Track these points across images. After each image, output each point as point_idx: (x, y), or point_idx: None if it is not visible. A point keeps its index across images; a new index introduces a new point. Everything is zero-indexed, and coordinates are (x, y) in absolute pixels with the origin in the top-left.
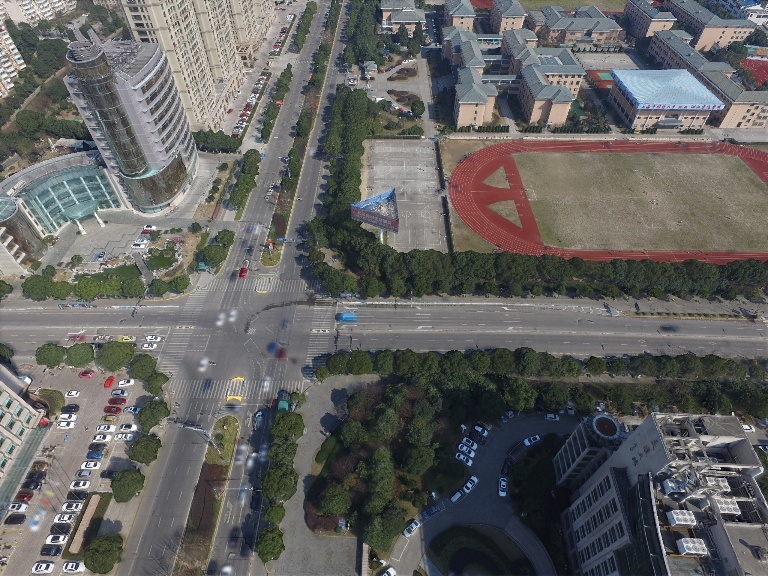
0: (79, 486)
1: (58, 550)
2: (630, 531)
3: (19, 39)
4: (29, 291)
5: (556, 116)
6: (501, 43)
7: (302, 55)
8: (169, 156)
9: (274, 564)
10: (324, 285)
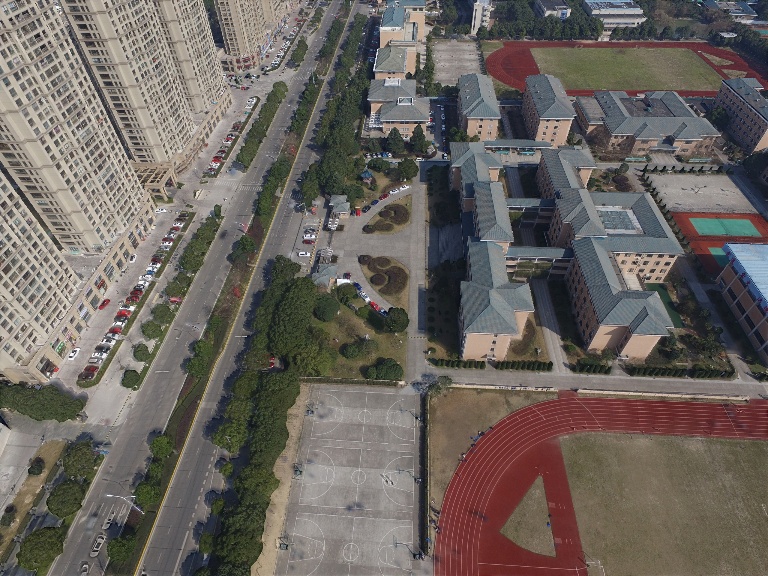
0: None
1: None
2: None
3: None
4: None
5: (636, 348)
6: None
7: (249, 174)
8: None
9: None
10: None
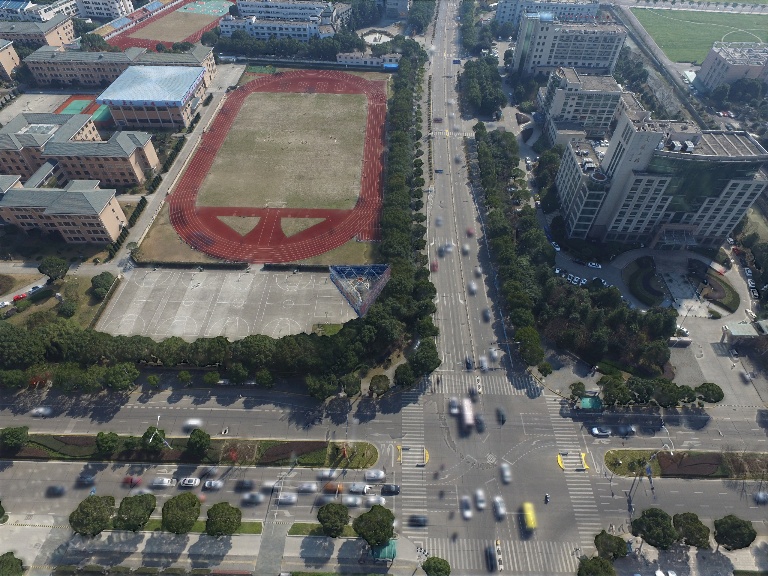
0: None
1: None
2: None
3: None
4: None
5: (152, 158)
6: None
7: None
8: None
9: None
10: None
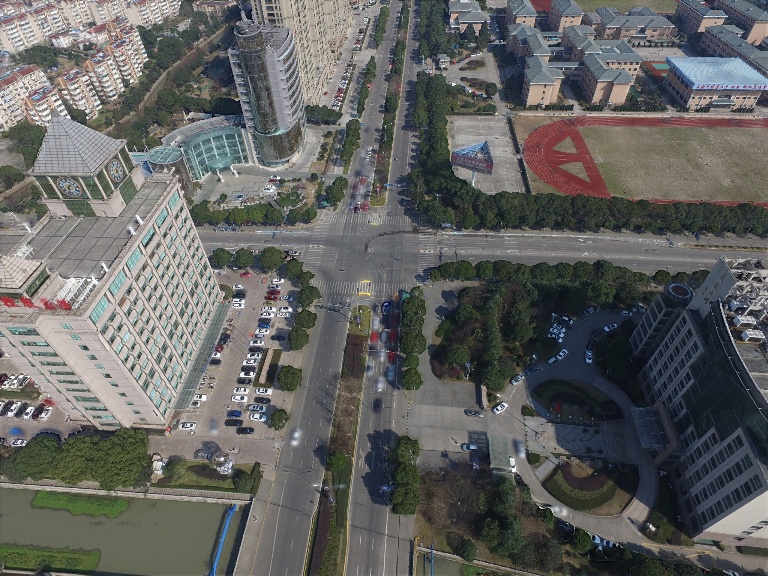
0: (257, 343)
1: (250, 381)
2: (704, 342)
3: (141, 38)
4: (195, 216)
5: (616, 96)
6: (561, 39)
7: (380, 50)
8: (294, 119)
9: (413, 397)
10: (429, 216)
